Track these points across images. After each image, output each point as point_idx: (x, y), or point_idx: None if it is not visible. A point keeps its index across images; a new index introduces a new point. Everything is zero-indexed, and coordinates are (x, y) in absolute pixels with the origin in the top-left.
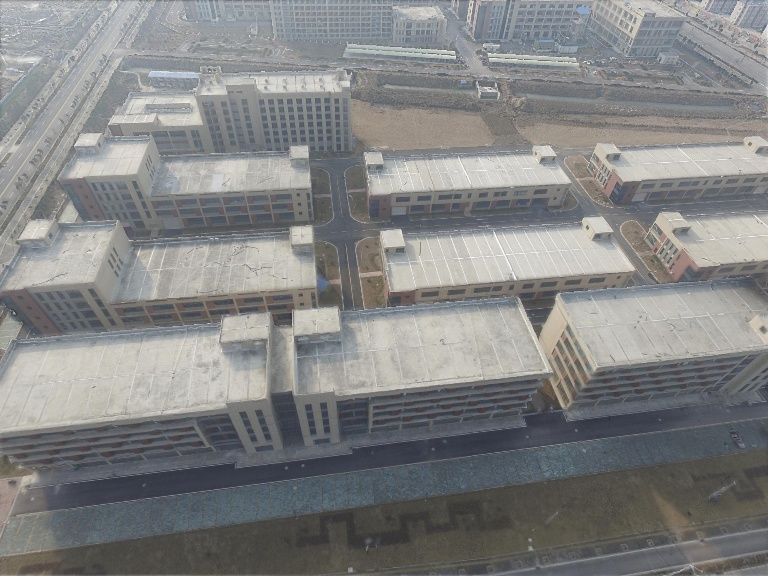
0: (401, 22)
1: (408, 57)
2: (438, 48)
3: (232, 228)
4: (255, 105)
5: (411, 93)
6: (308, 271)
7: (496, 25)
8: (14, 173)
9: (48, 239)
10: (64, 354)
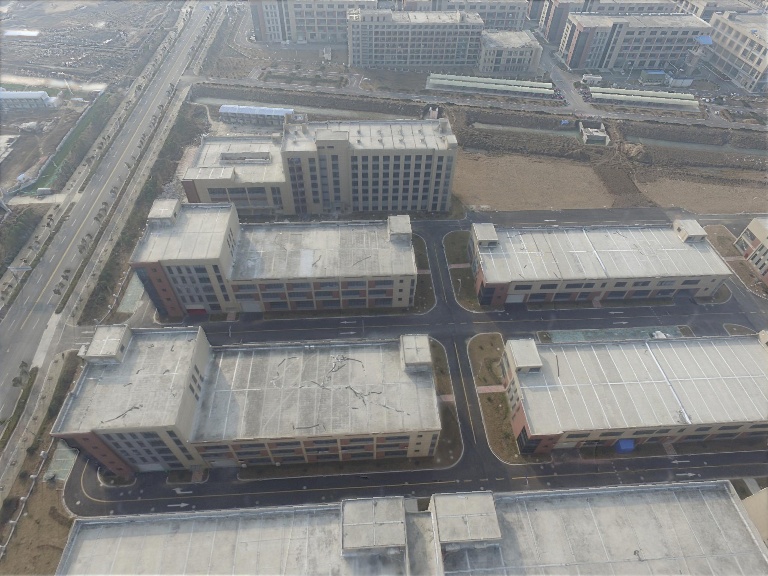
0: (491, 50)
1: (499, 90)
2: (530, 79)
3: (319, 314)
4: (346, 162)
5: (507, 135)
6: (427, 401)
7: (596, 53)
8: (77, 229)
9: (119, 354)
10: (140, 545)
